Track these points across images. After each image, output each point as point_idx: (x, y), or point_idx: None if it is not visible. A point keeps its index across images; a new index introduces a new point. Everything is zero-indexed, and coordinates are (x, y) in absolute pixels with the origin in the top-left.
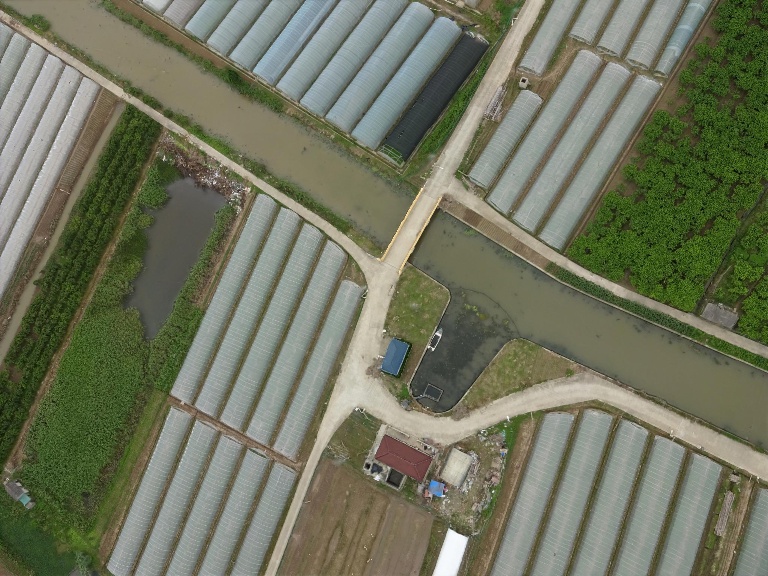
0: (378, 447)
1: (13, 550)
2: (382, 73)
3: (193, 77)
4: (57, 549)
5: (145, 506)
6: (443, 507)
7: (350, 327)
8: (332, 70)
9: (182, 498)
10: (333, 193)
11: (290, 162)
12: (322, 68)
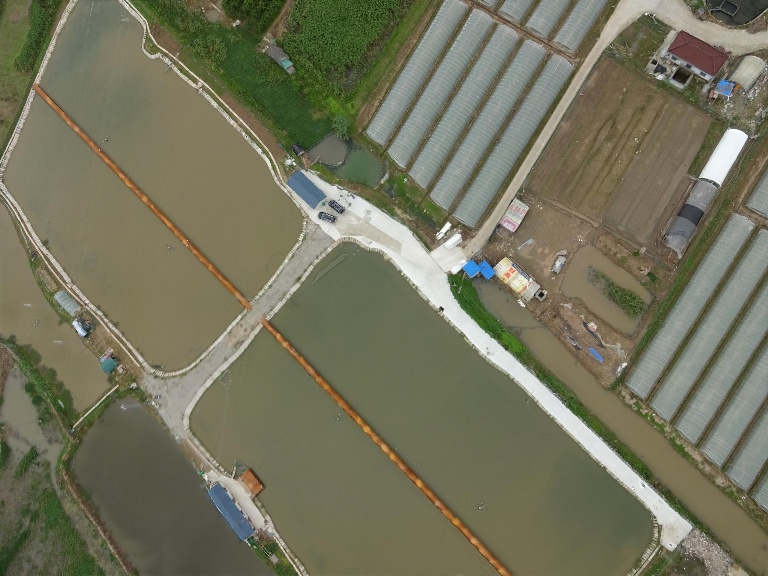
0: (667, 48)
1: (267, 111)
2: None
3: None
4: (312, 115)
5: (413, 80)
6: (725, 110)
7: None
8: None
9: (452, 76)
10: None
11: None
12: None
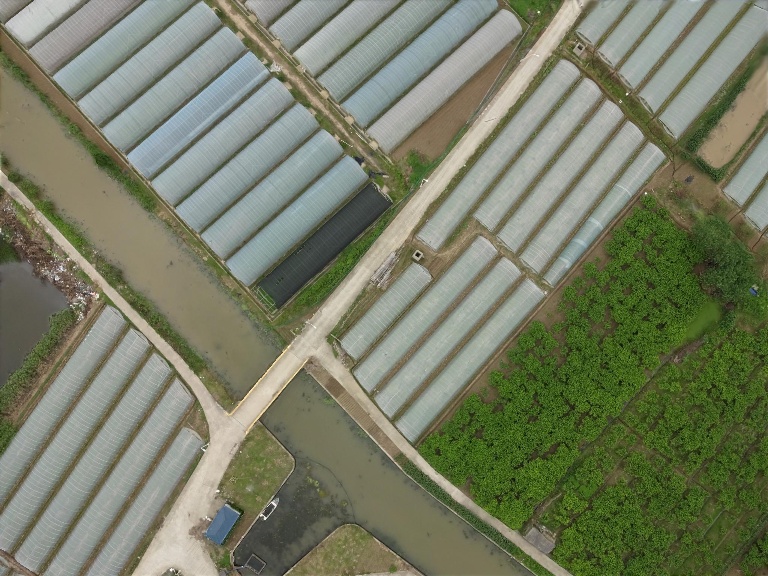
0: None
1: None
2: (274, 203)
3: (54, 138)
4: None
5: None
6: None
7: (182, 479)
8: (219, 185)
9: None
10: (193, 324)
11: (151, 274)
12: (209, 175)
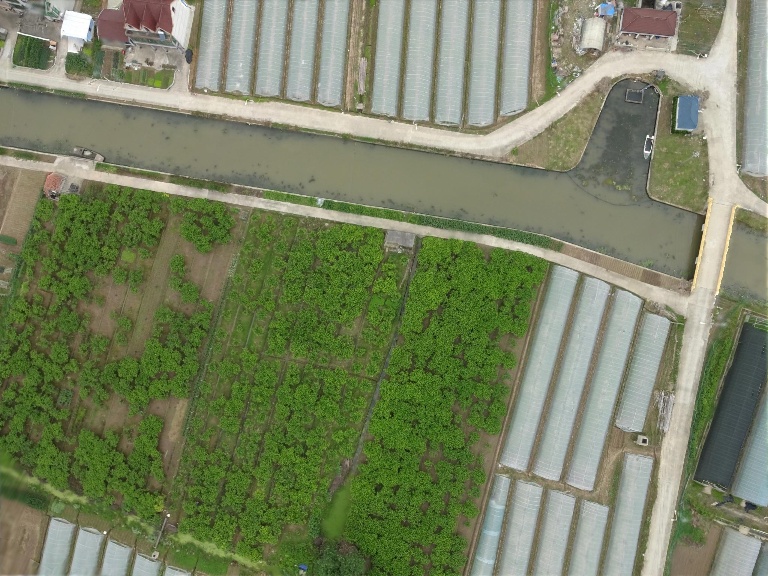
0: None
1: None
2: None
3: None
4: None
5: None
6: None
7: (742, 132)
8: None
9: None
10: None
11: None
12: None
